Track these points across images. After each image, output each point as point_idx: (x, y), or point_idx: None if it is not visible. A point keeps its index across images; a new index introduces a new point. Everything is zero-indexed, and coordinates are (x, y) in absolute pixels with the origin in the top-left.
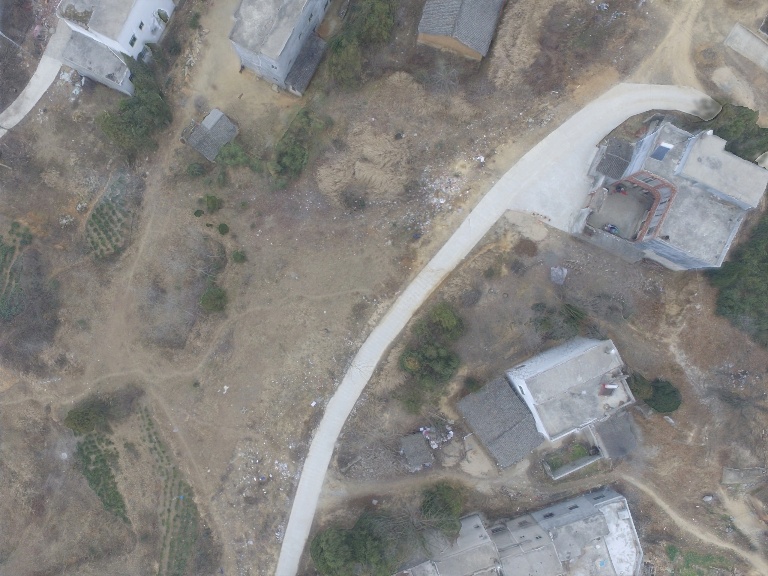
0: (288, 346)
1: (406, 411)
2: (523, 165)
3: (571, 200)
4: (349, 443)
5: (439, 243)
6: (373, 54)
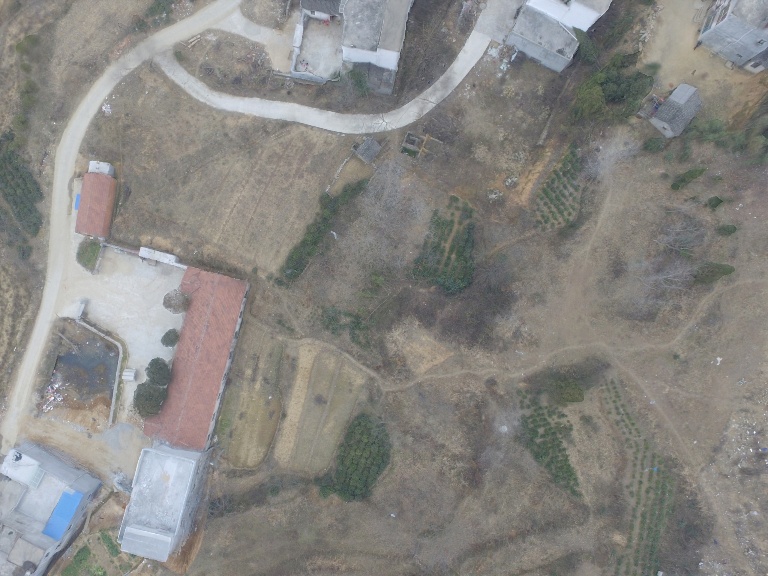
0: None
1: None
2: None
3: None
4: None
5: None
6: None
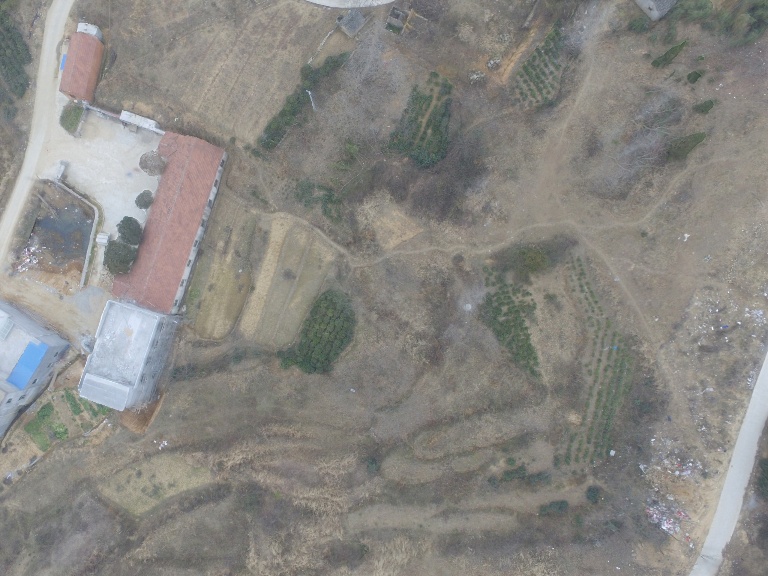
0: (762, 196)
1: None
2: None
3: None
4: None
5: None
6: None
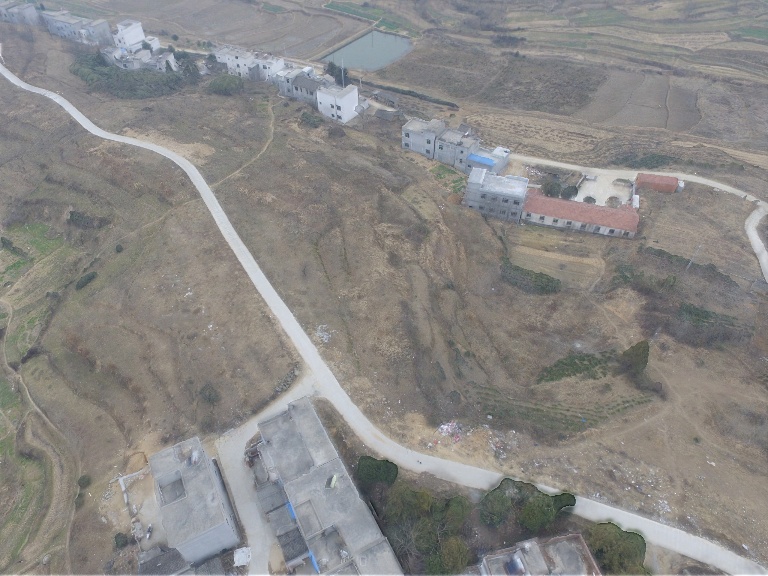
0: None
1: None
2: None
3: None
4: None
5: None
6: None
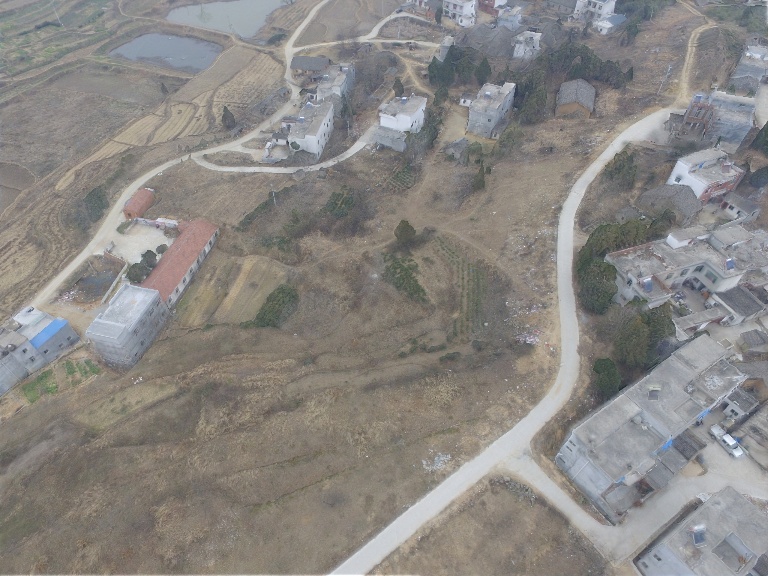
0: (529, 192)
1: (612, 202)
2: (630, 129)
3: (662, 137)
4: (584, 215)
5: (600, 152)
6: (540, 109)
